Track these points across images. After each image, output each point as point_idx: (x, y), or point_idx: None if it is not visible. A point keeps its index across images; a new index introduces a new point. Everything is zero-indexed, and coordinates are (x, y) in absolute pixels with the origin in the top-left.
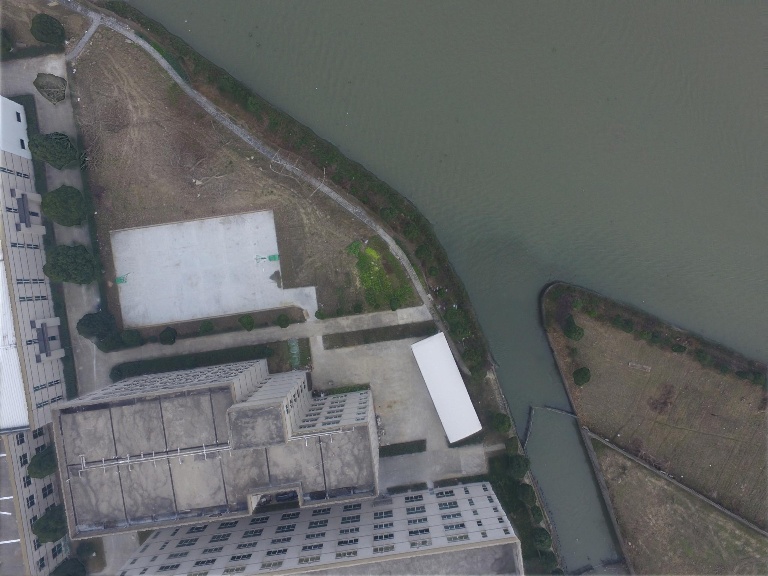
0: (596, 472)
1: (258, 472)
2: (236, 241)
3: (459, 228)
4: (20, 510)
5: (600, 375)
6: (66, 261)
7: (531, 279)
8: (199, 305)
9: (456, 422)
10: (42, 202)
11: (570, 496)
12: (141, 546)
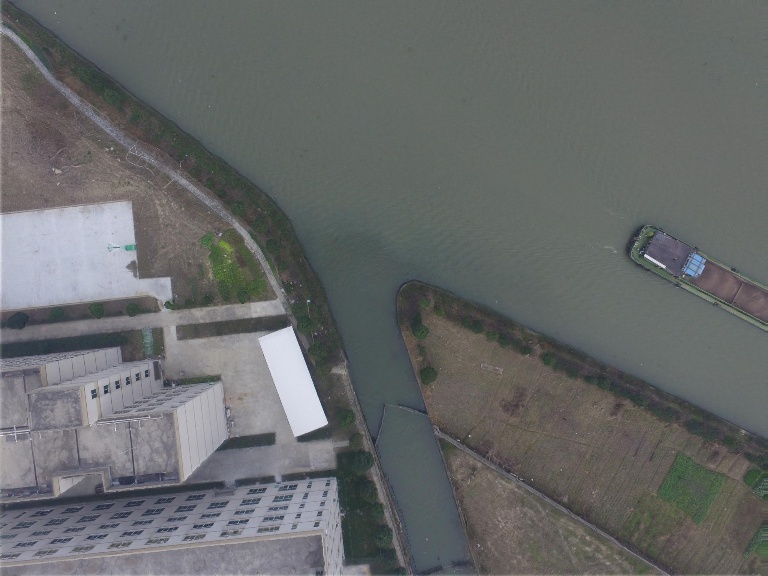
0: None
1: (68, 455)
2: (94, 230)
3: (317, 224)
4: None
5: (451, 375)
6: None
7: (389, 277)
8: (56, 292)
9: (301, 416)
10: None
11: (422, 495)
12: None
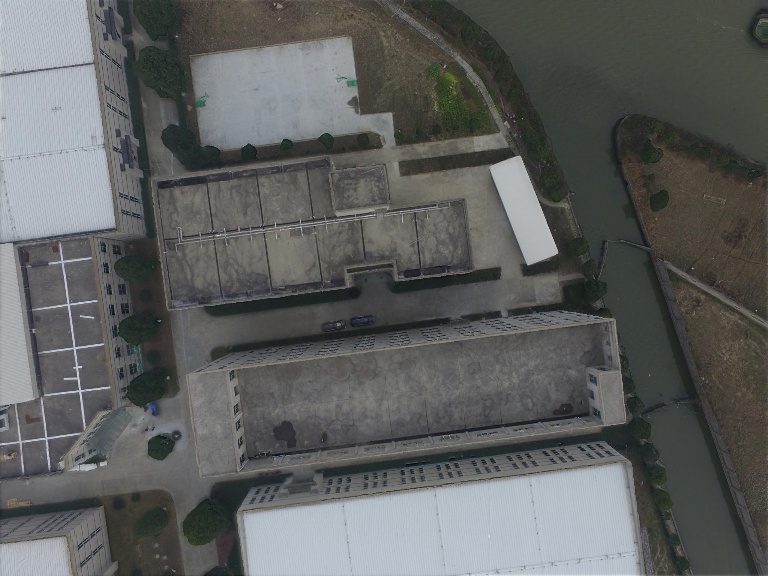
0: (670, 306)
1: (353, 249)
2: (314, 67)
3: (534, 60)
4: (104, 312)
5: (675, 206)
6: (157, 58)
7: (605, 113)
8: (277, 130)
9: (533, 244)
10: (134, 1)
11: (642, 332)
12: (220, 358)
